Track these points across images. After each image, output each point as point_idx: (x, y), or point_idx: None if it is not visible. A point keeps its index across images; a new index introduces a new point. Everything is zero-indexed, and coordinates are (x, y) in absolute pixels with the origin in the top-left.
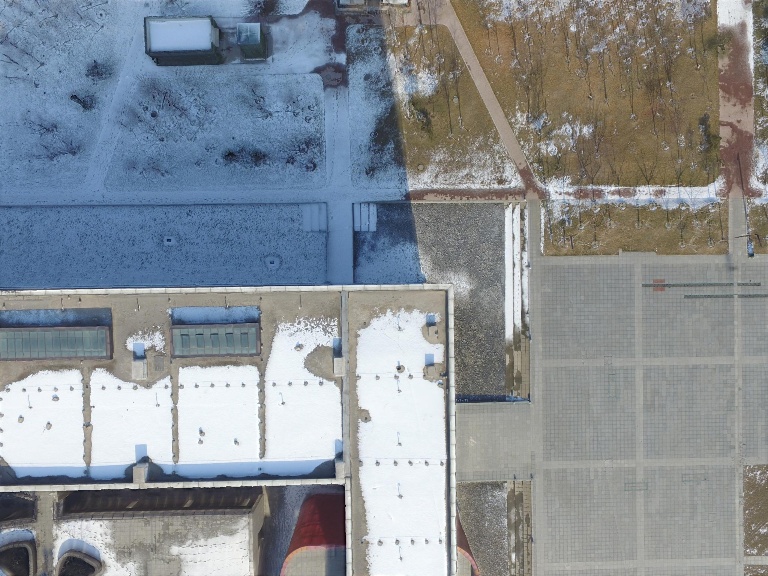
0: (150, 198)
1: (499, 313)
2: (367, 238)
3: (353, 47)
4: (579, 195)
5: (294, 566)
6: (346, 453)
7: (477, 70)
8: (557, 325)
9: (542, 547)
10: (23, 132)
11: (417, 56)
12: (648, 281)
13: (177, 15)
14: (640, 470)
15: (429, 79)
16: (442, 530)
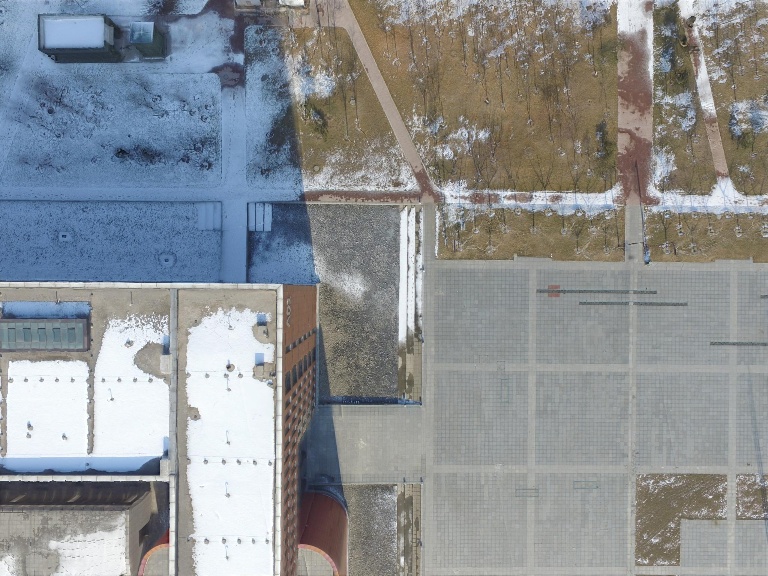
0: (45, 194)
1: (393, 315)
2: (262, 238)
3: (251, 48)
4: (475, 199)
5: (155, 563)
6: (171, 450)
7: (375, 73)
8: (450, 329)
9: (431, 551)
10: None
11: (315, 58)
12: (543, 287)
13: None
14: (531, 476)
15: (326, 81)
16: (269, 530)
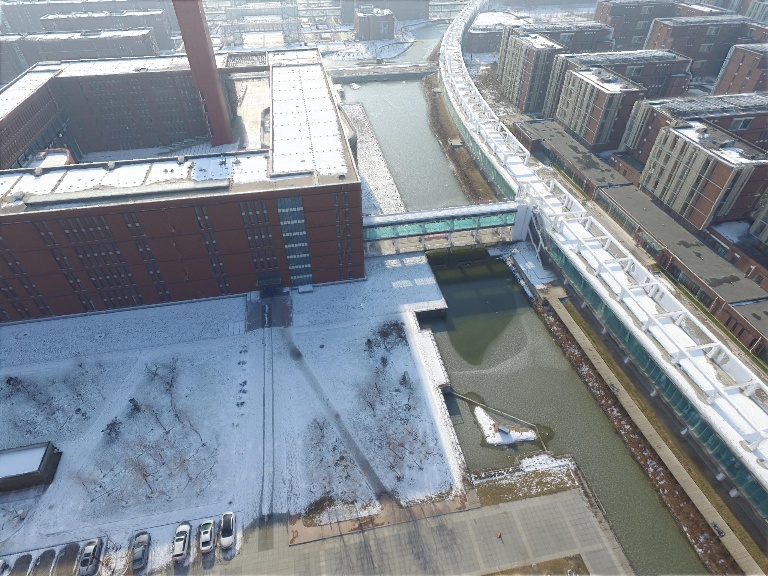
0: (103, 356)
1: None
2: None
3: None
4: None
5: None
6: None
7: None
8: None
9: None
10: (195, 382)
11: None
12: None
13: (22, 502)
14: None
15: None
16: None
